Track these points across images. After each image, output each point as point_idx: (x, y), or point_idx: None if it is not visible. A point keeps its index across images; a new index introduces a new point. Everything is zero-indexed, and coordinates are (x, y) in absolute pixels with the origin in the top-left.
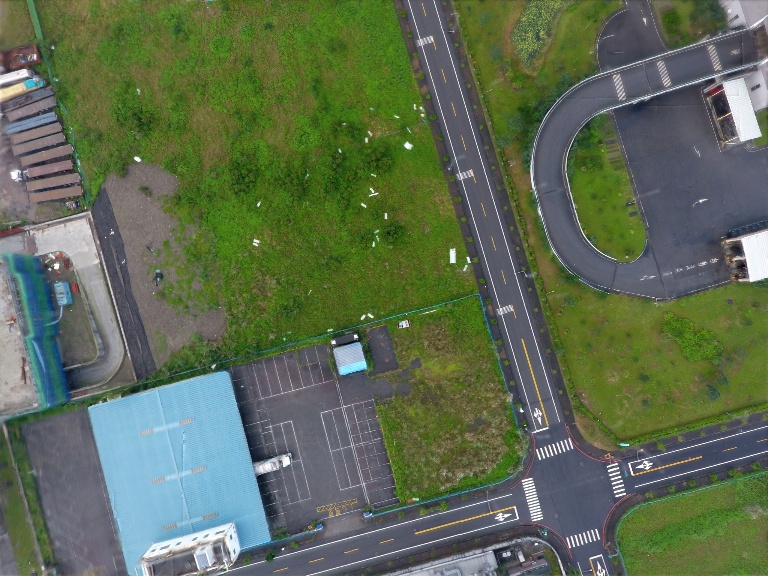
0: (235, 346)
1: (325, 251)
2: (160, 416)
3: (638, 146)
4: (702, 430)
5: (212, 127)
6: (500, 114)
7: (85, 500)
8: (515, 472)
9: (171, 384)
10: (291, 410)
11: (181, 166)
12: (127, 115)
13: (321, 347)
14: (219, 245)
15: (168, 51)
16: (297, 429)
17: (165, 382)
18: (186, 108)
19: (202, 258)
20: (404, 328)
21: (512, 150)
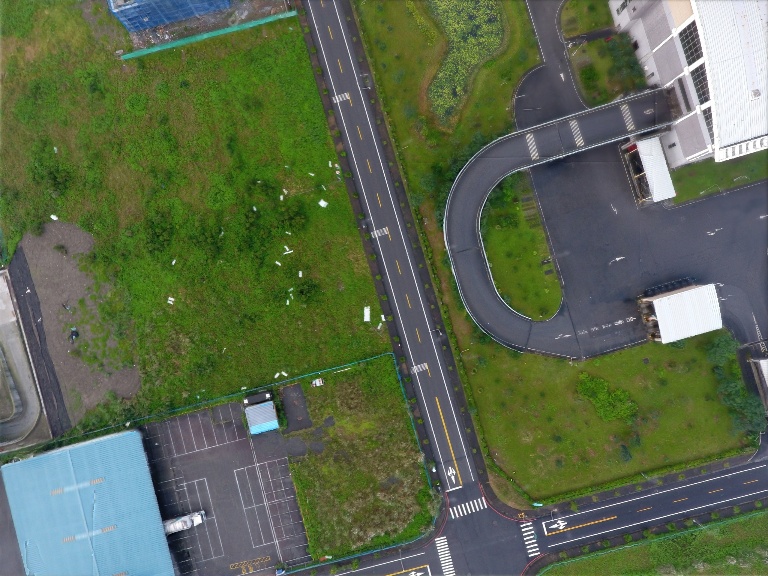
0: (149, 404)
1: (239, 309)
2: (71, 476)
3: (554, 203)
4: (617, 490)
5: (128, 185)
6: (415, 171)
7: (2, 555)
8: (427, 532)
9: (83, 444)
10: (205, 467)
11: (97, 224)
12: (43, 174)
13: (235, 405)
14: (134, 303)
15: (84, 109)
16: (211, 486)
17: (80, 439)
18: (102, 166)
19: (117, 316)
20: (317, 386)
21: (427, 207)
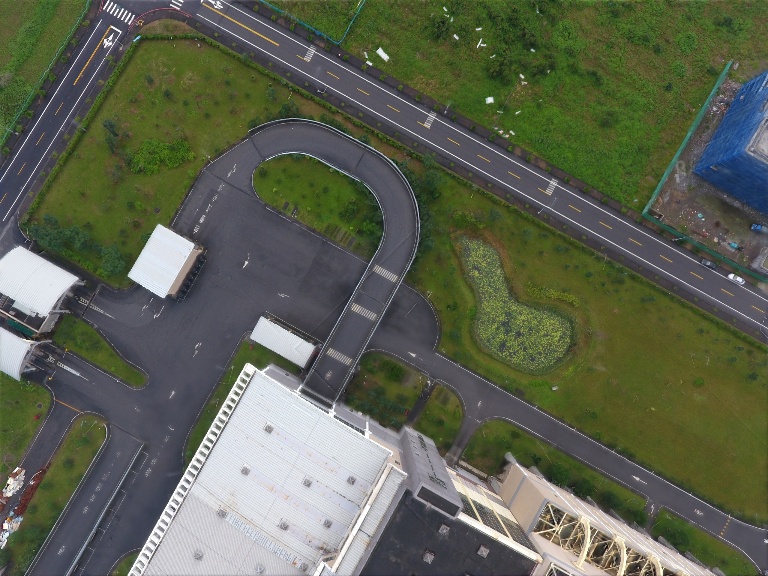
0: None
1: None
2: None
3: (329, 258)
4: (92, 103)
5: None
6: (448, 186)
7: None
8: None
9: None
10: None
11: None
12: None
13: None
14: None
15: (719, 3)
16: None
17: None
18: None
19: None
20: None
21: (415, 169)
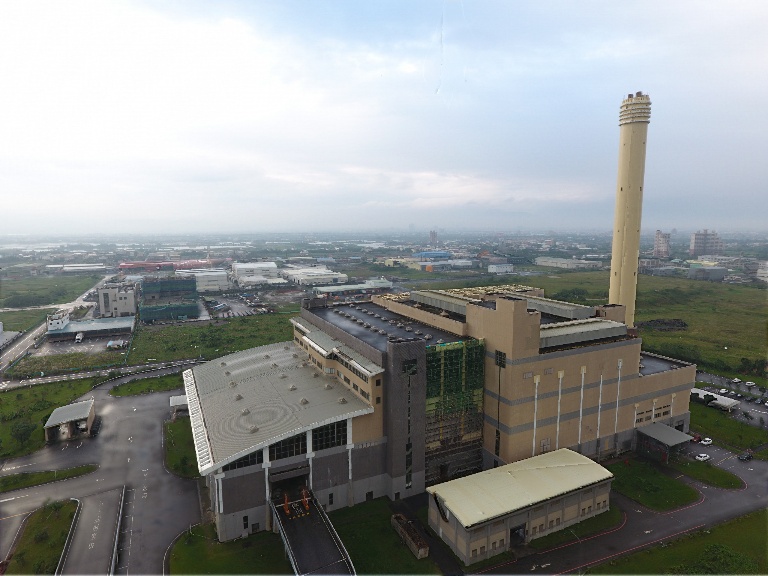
0: None
1: None
2: None
3: None
4: None
5: None
6: None
7: None
8: None
9: None
10: None
11: None
12: None
13: None
14: None
15: None
16: None
17: None
18: None
19: None
20: None
21: None
